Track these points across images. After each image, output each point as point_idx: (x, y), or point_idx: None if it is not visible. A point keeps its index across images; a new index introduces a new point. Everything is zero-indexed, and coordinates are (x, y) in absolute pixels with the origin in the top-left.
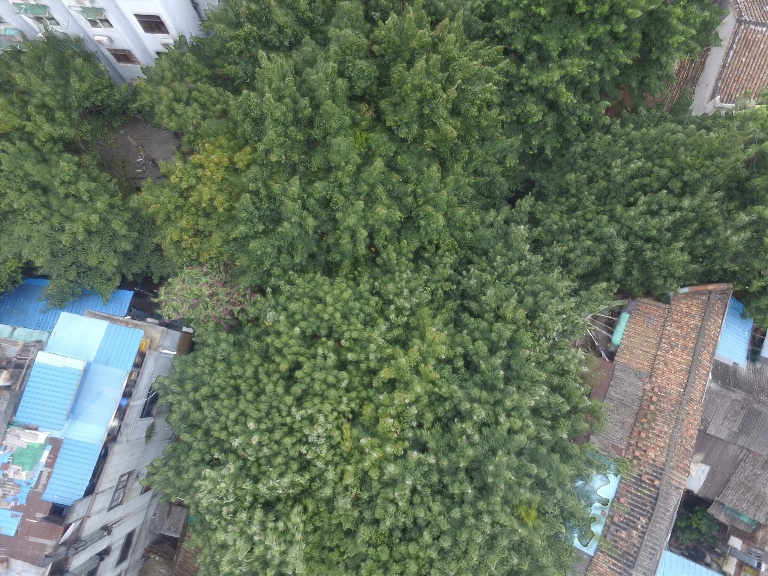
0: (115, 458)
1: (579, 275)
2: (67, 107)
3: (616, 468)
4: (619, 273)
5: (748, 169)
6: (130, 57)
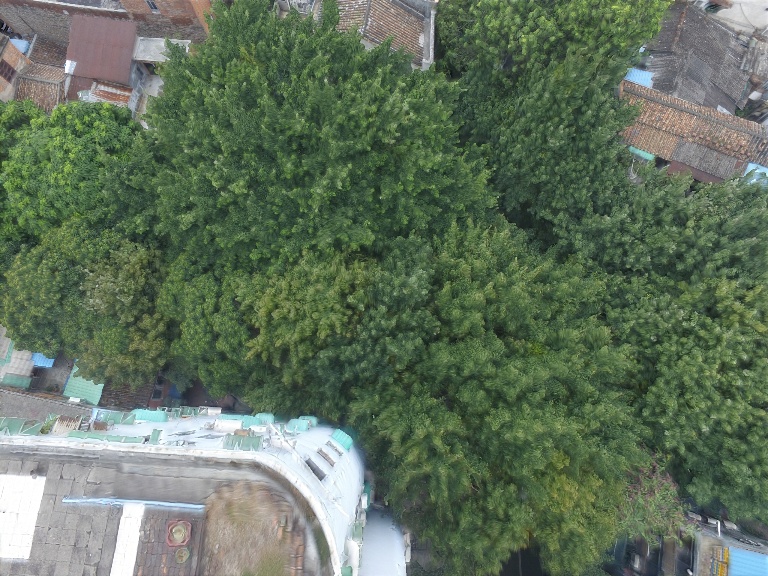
0: None
1: None
2: None
3: None
4: None
5: (552, 52)
6: None
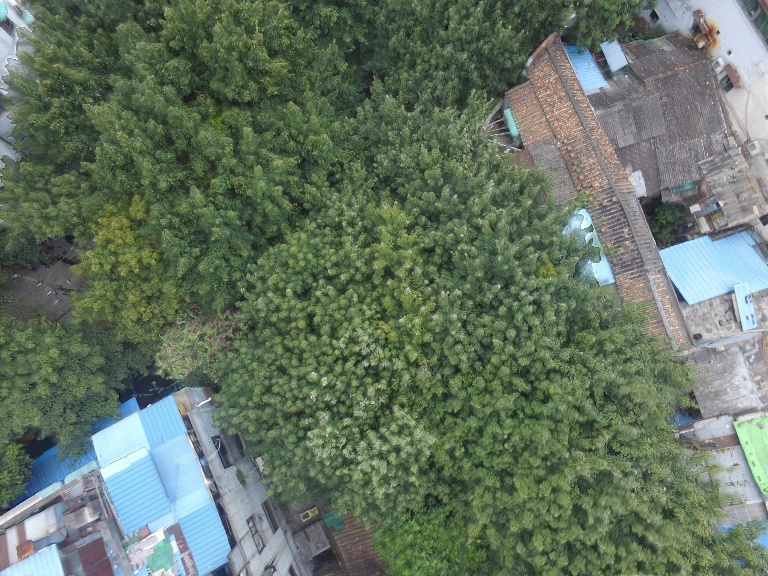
0: (231, 508)
1: (453, 102)
2: None
3: (580, 202)
4: (478, 81)
5: None
6: None
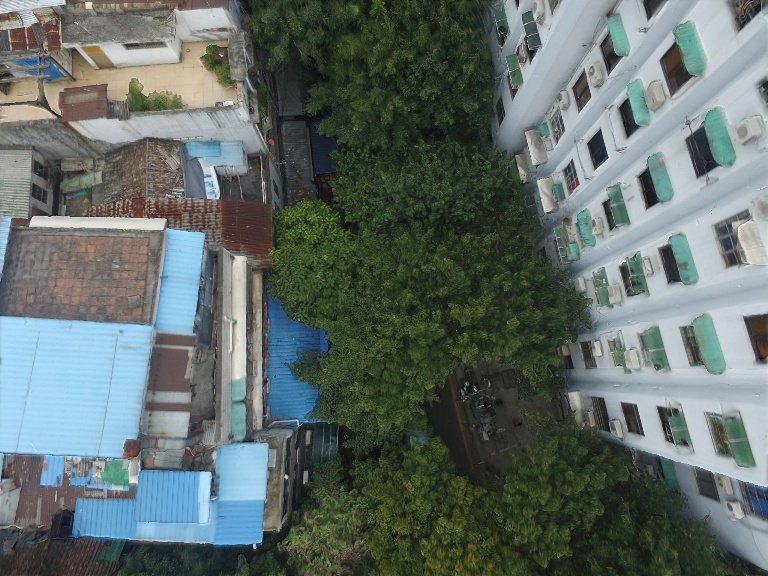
0: None
1: None
2: None
3: None
4: None
5: None
6: (590, 360)
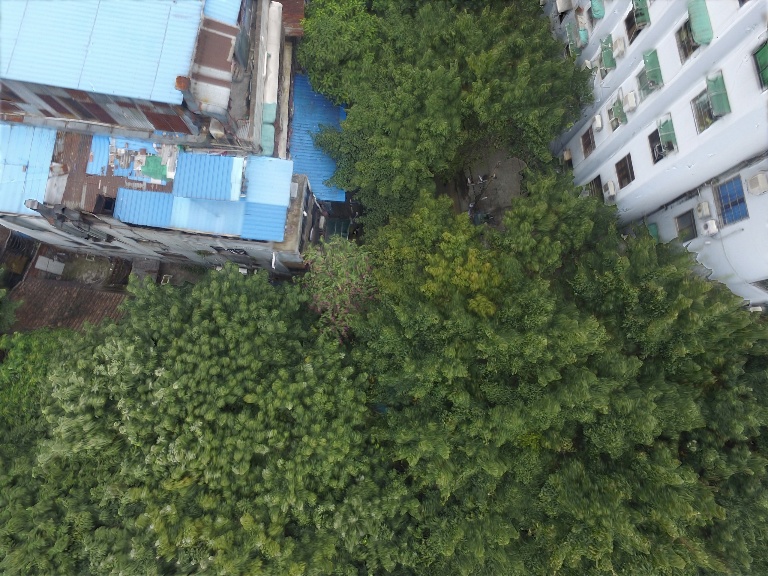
0: (166, 237)
1: None
2: (511, 110)
3: None
4: None
5: None
6: (590, 148)
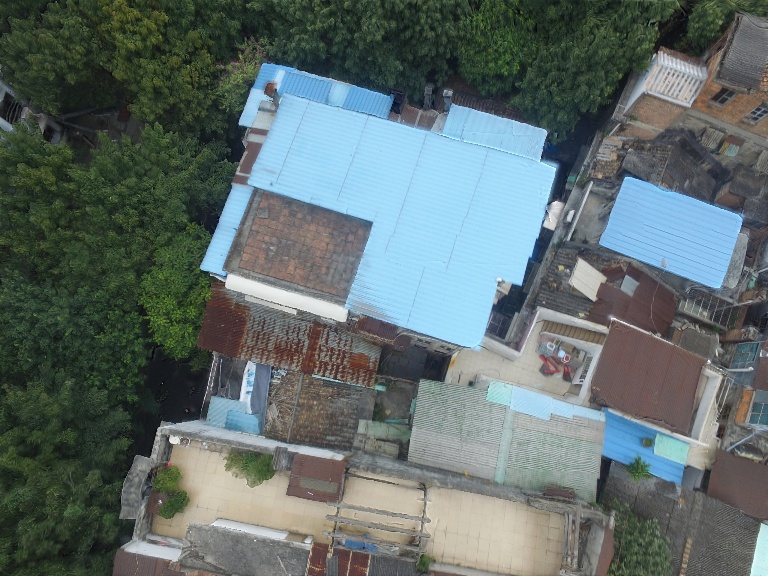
0: None
1: None
2: None
3: None
4: None
5: None
6: None
